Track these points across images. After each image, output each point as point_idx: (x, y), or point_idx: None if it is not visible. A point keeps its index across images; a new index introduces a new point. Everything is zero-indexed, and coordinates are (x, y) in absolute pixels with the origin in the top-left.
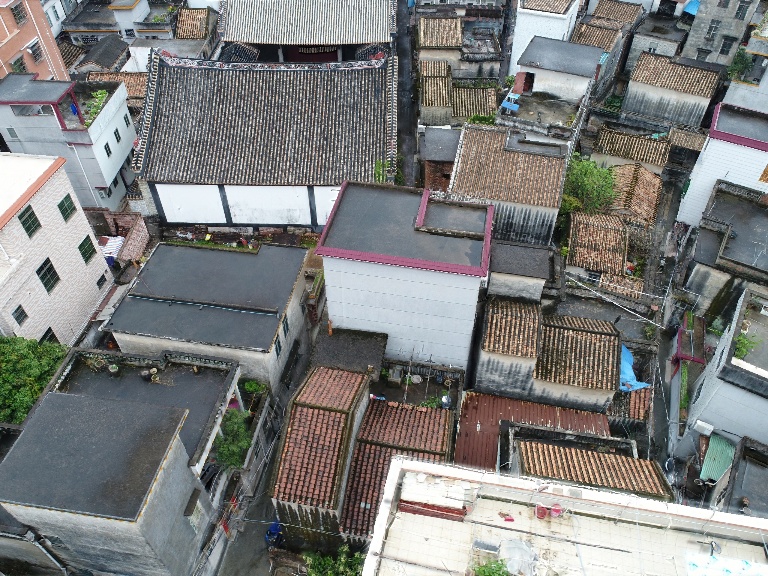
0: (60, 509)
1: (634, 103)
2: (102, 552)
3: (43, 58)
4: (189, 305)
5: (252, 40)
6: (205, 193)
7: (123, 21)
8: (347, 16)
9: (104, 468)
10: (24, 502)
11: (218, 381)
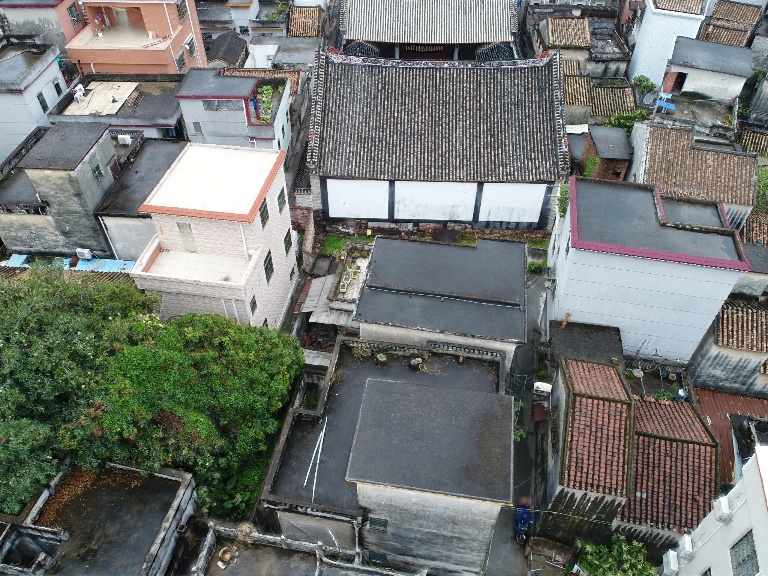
0: (432, 491)
1: (766, 104)
2: (423, 535)
3: (195, 54)
4: (429, 297)
5: (373, 38)
6: (374, 188)
7: (239, 18)
8: (467, 15)
9: (457, 452)
10: (393, 484)
11: (484, 371)
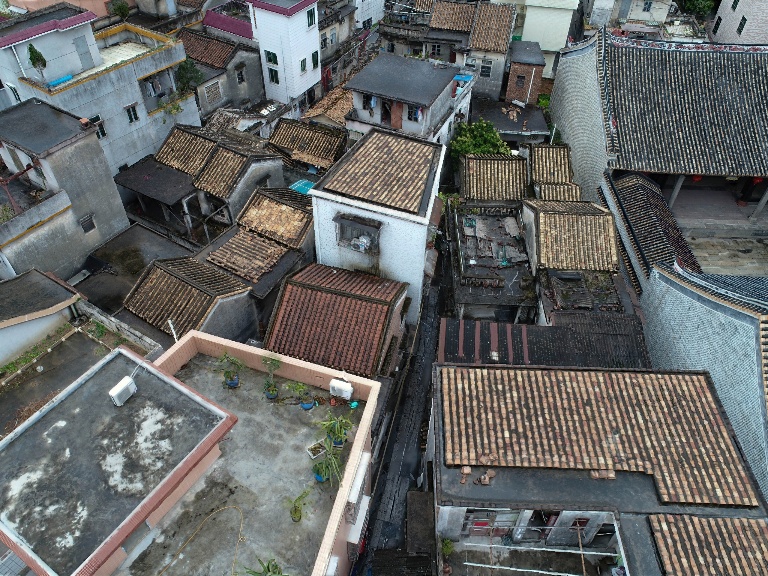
0: None
1: None
2: None
3: None
4: None
5: None
6: None
7: None
8: None
9: None
10: None
11: None
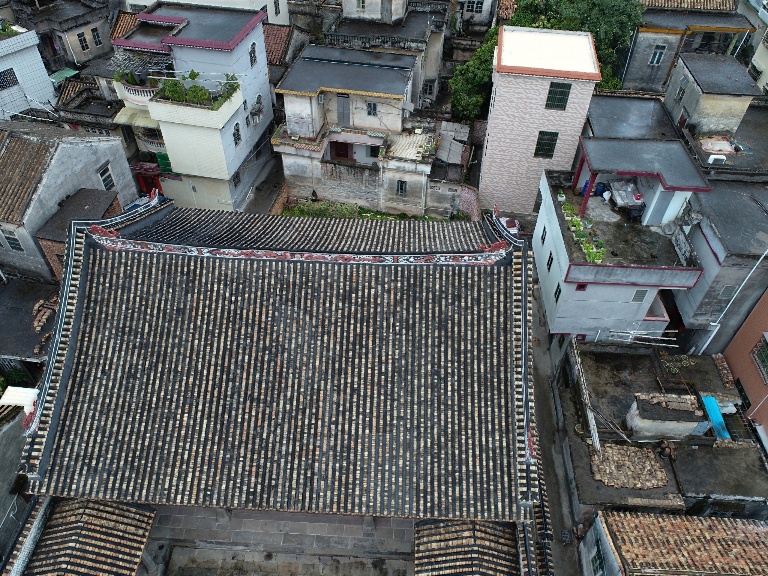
0: None
1: None
2: None
3: None
4: None
5: None
6: None
7: None
8: None
9: None
10: None
11: None
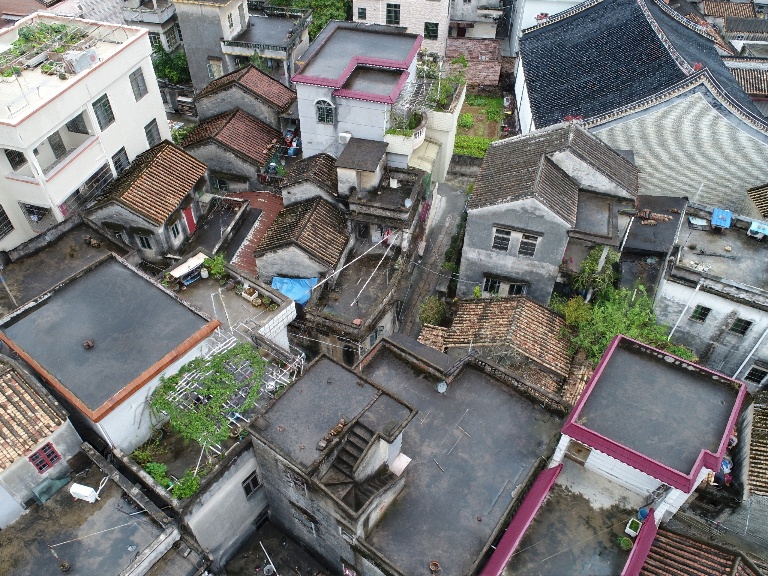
0: None
1: None
2: None
3: None
4: None
5: None
6: None
7: None
8: None
9: None
10: None
11: None
